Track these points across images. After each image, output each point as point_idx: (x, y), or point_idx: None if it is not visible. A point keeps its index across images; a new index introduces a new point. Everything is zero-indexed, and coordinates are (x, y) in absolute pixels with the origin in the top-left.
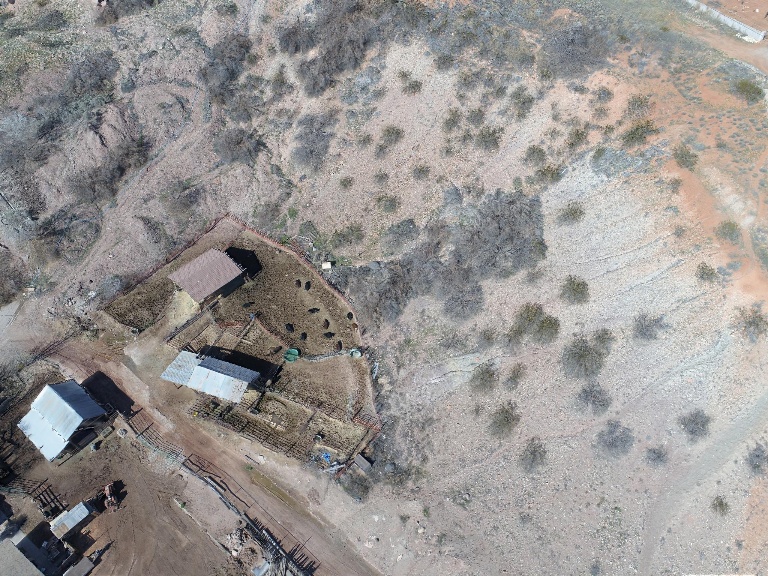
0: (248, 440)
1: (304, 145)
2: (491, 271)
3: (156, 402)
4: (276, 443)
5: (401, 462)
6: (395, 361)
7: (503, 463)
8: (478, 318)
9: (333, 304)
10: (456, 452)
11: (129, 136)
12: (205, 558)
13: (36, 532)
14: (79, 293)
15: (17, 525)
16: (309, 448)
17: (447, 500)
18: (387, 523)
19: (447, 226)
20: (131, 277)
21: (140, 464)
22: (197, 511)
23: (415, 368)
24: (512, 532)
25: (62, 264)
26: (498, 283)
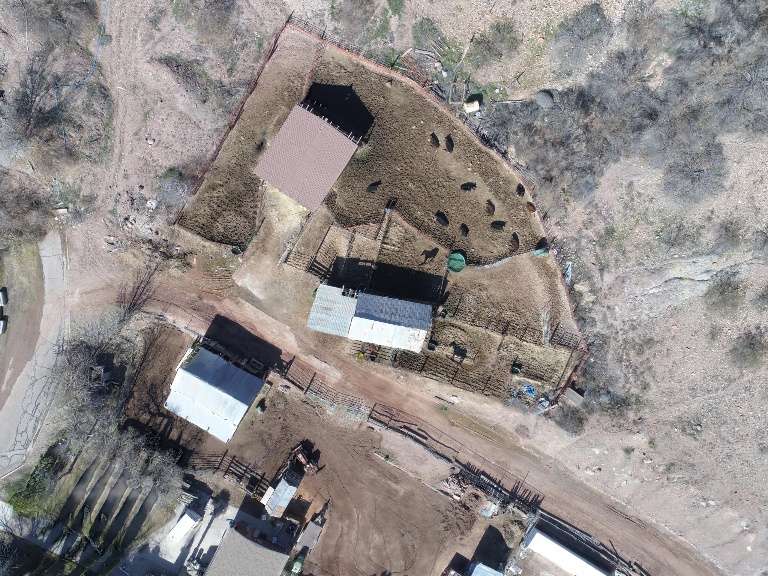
0: (434, 381)
1: None
2: (739, 118)
3: (307, 345)
4: (467, 380)
5: (617, 390)
6: (596, 262)
7: (744, 395)
8: (716, 201)
9: (493, 172)
10: (684, 380)
11: None
12: (427, 503)
13: (247, 505)
14: (133, 207)
15: (223, 501)
16: (507, 382)
17: (675, 431)
18: (610, 456)
19: (659, 17)
20: (192, 166)
21: (320, 420)
22: (404, 463)
23: (624, 272)
24: (748, 461)
25: (85, 167)
26: (751, 143)
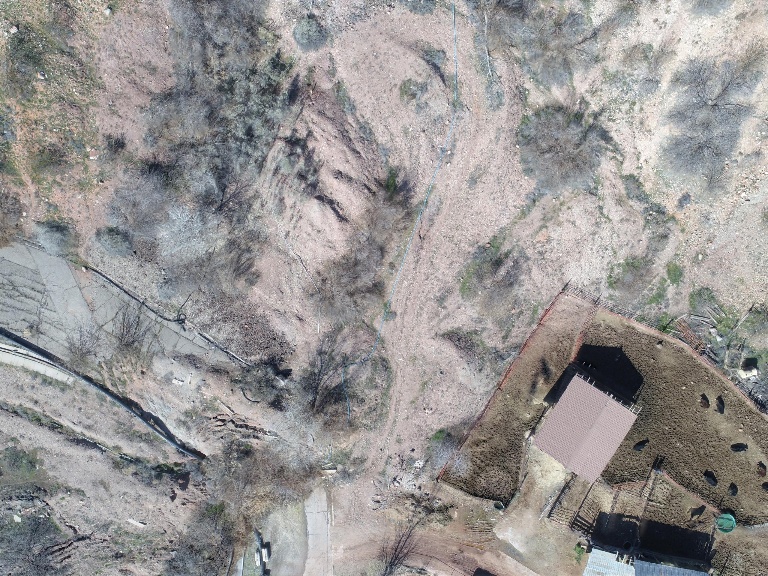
0: None
1: (686, 132)
2: None
3: None
4: None
5: None
6: None
7: None
8: None
9: (765, 434)
10: None
11: (373, 182)
12: None
13: None
14: (402, 468)
15: None
16: None
17: None
18: None
19: None
20: (460, 426)
21: None
22: None
23: None
24: None
25: (361, 434)
26: None
